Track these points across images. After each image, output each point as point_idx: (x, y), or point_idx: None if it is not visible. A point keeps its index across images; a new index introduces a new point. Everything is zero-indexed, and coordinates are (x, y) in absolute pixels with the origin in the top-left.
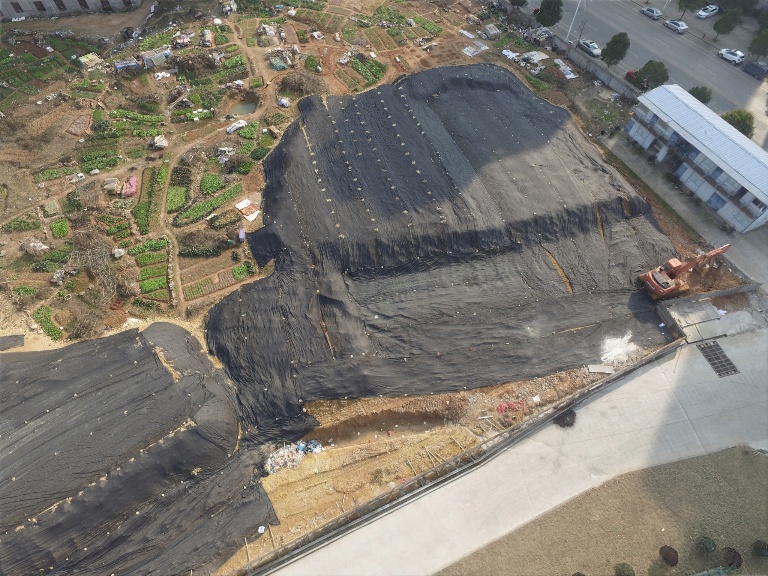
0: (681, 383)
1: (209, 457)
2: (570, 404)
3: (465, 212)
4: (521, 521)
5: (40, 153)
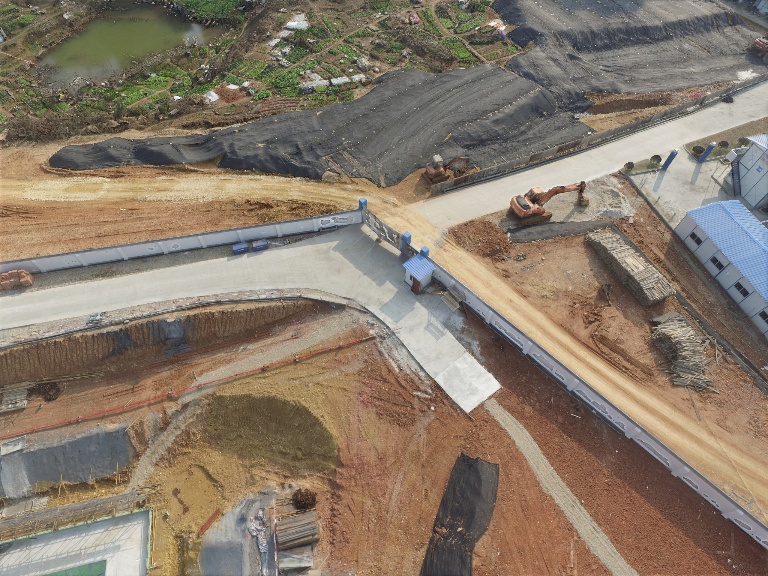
0: None
1: (549, 108)
2: (728, 95)
3: (636, 18)
4: (721, 130)
5: (346, 4)
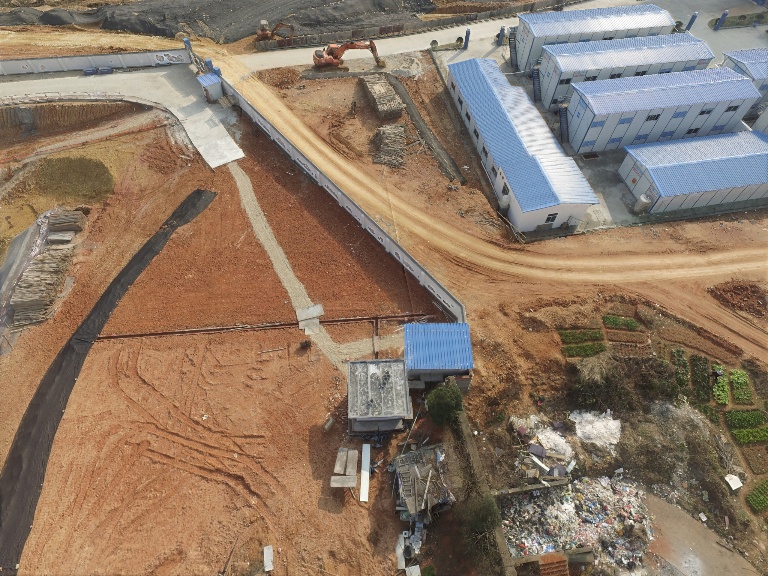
0: (617, 2)
1: (392, 6)
2: None
3: None
4: None
5: None
